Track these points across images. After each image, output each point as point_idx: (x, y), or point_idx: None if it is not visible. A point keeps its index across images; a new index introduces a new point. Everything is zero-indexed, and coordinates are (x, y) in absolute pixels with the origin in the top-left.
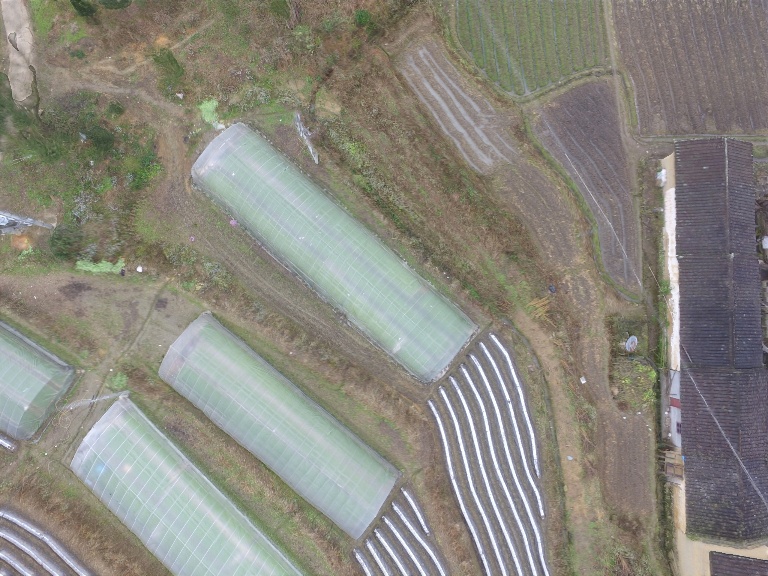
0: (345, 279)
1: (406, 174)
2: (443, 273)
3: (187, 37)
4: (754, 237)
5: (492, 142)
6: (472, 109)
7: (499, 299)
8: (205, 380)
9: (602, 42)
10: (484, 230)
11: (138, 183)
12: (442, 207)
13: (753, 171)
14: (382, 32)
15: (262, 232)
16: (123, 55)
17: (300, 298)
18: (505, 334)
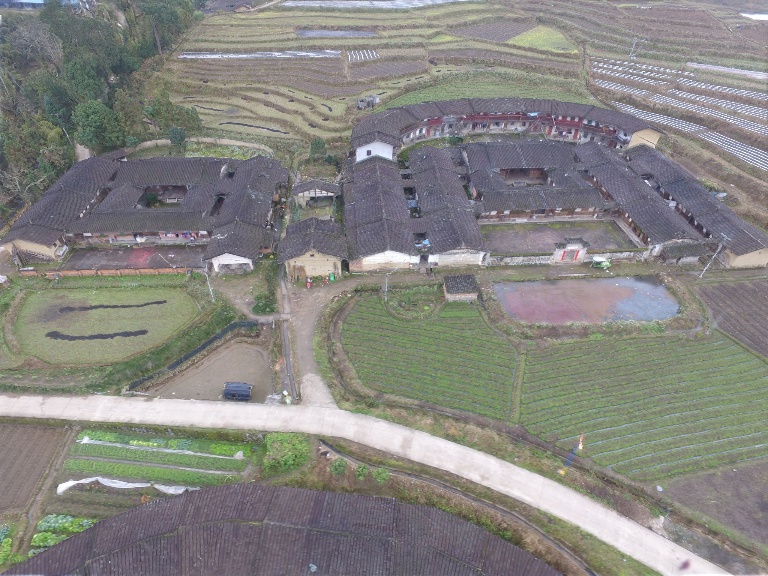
0: None
1: None
2: None
3: None
4: None
5: None
6: None
7: None
8: None
9: None
10: None
11: None
12: None
13: None
14: None
15: None
16: None
17: None
18: None
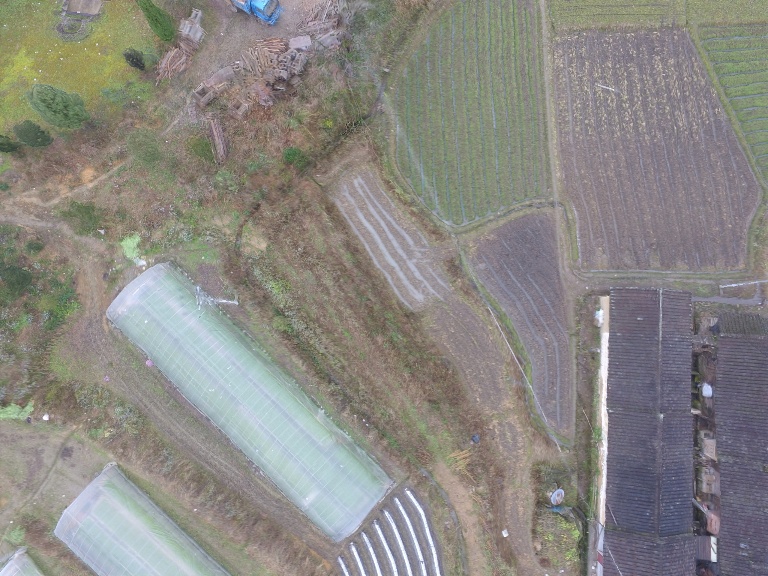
0: (254, 435)
1: (330, 314)
2: (362, 421)
3: (113, 168)
4: (689, 392)
5: (424, 277)
6: (405, 242)
7: (418, 451)
8: (98, 547)
9: (545, 172)
10: (406, 377)
11: (52, 324)
12: (365, 350)
13: (696, 313)
14: (314, 164)
15: (174, 380)
16: (48, 186)
17: (213, 444)
18: (421, 490)
